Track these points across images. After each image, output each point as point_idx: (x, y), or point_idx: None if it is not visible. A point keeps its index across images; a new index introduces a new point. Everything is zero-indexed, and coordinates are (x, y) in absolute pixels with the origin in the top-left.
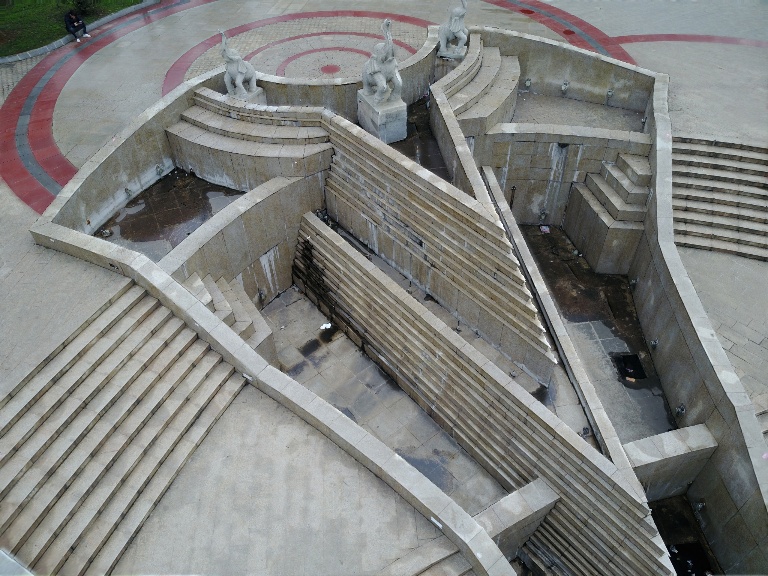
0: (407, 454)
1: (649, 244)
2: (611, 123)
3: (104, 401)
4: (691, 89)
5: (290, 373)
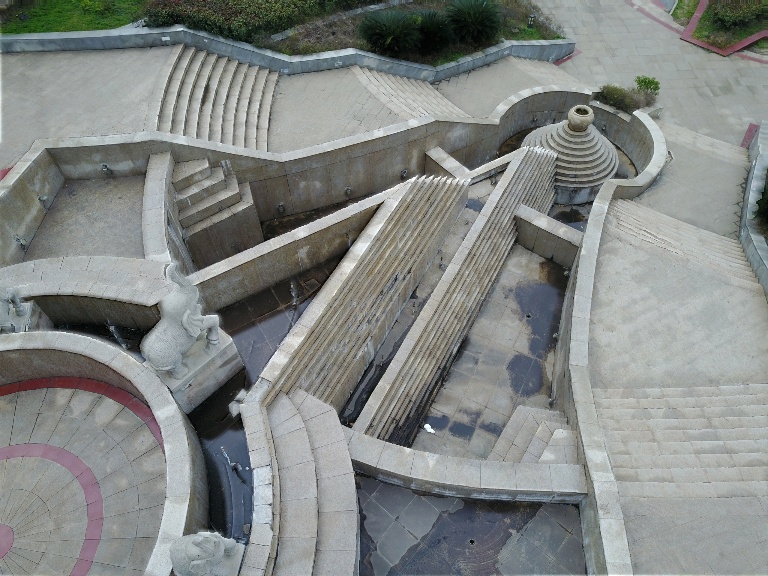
0: (520, 313)
1: (271, 177)
2: (92, 203)
3: (711, 445)
4: (47, 134)
5: (500, 433)
